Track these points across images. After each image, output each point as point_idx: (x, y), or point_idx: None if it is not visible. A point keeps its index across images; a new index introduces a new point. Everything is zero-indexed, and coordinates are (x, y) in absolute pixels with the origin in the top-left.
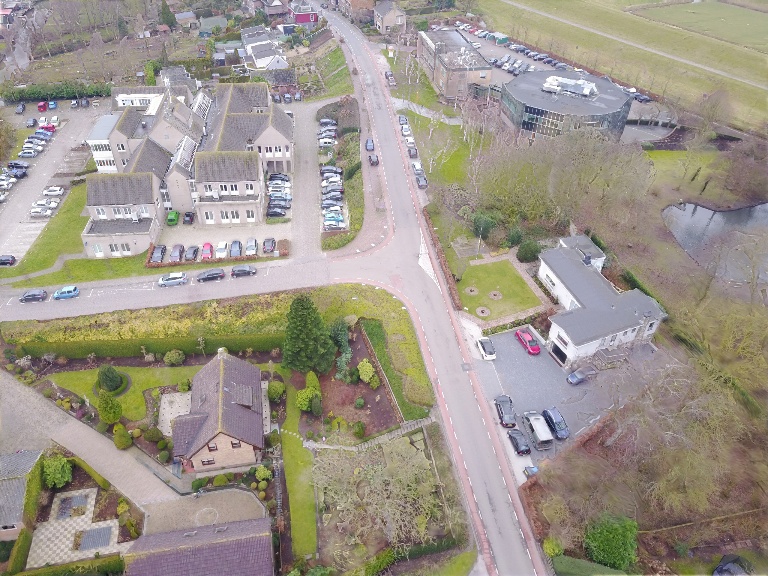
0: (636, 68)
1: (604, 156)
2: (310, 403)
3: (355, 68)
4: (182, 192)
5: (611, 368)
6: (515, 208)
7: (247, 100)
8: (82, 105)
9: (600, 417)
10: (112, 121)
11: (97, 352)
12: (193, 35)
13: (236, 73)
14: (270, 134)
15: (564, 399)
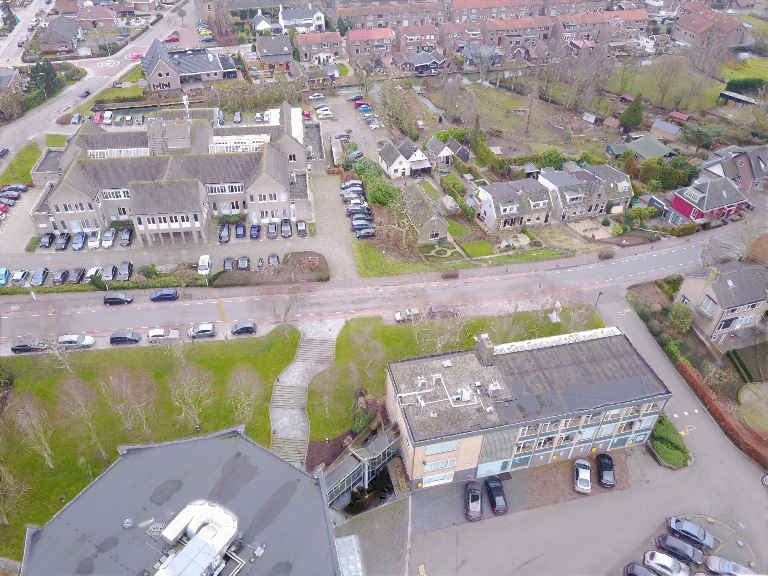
0: None
1: None
2: None
3: (455, 270)
4: None
5: None
6: None
7: (250, 173)
8: None
9: None
10: None
11: None
12: None
13: None
14: None
15: None
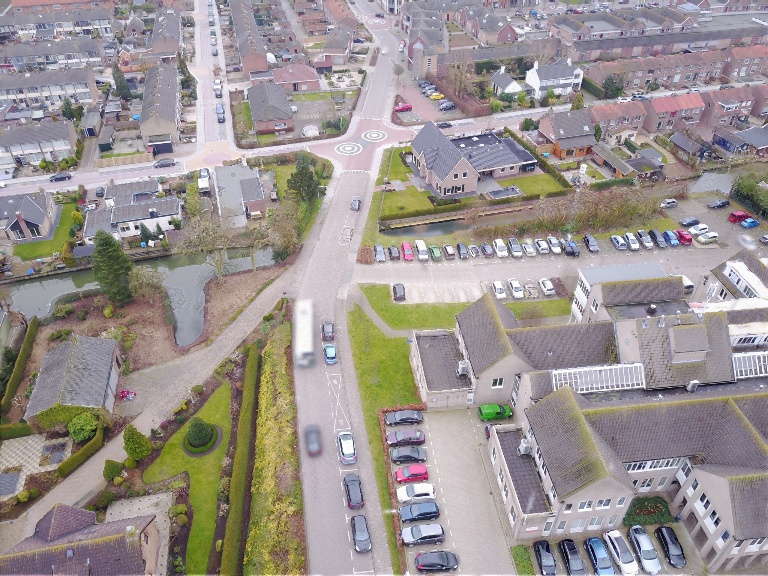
0: None
1: None
2: None
3: None
4: (525, 403)
5: None
6: None
7: None
8: None
9: None
10: (646, 276)
11: None
12: None
13: None
14: (720, 488)
15: None
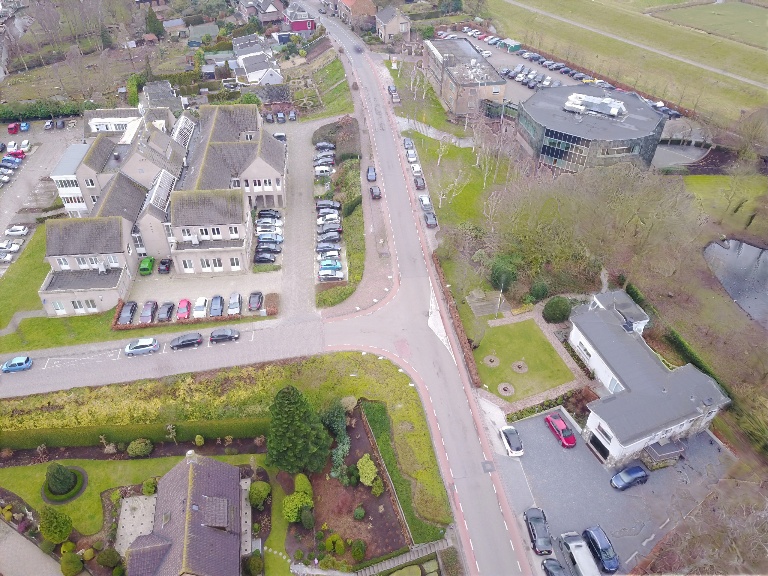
0: (661, 78)
1: (644, 197)
2: (299, 513)
3: (355, 82)
4: (157, 236)
5: (664, 467)
6: (539, 255)
7: (234, 124)
8: (57, 126)
9: (654, 537)
10: (81, 152)
11: (49, 442)
12: (182, 44)
13: (226, 88)
14: (258, 166)
15: (609, 511)
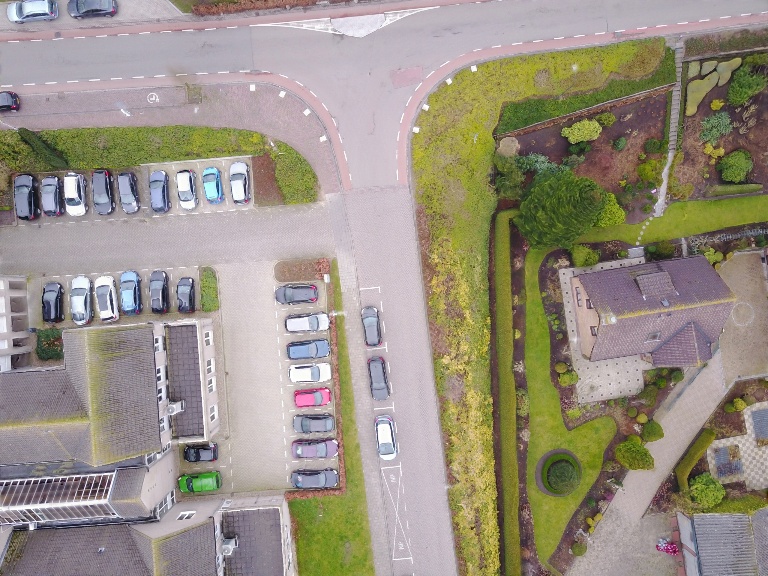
0: None
1: None
2: None
3: None
4: (158, 477)
5: None
6: None
7: None
8: None
9: None
10: None
11: None
12: None
13: None
14: None
15: None
